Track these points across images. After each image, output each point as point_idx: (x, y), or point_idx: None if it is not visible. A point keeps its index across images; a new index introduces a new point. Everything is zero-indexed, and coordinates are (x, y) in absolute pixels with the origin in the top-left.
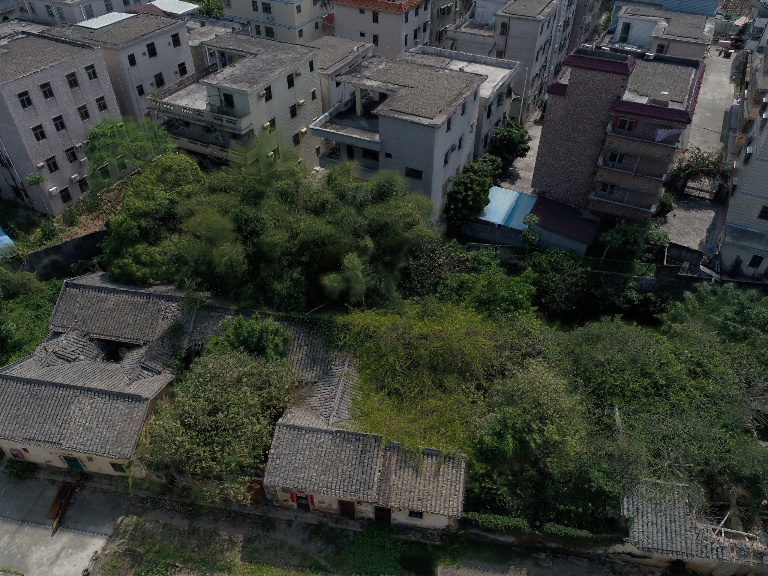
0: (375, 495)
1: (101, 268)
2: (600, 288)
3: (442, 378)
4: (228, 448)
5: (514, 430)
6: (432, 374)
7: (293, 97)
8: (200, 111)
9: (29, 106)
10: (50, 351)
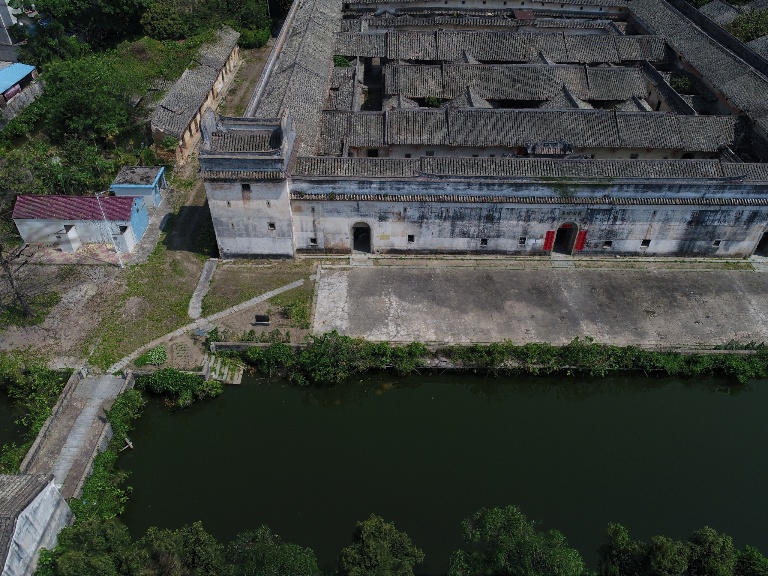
0: None
1: None
2: None
3: None
4: None
5: None
6: None
7: None
8: None
9: None
10: (739, 6)
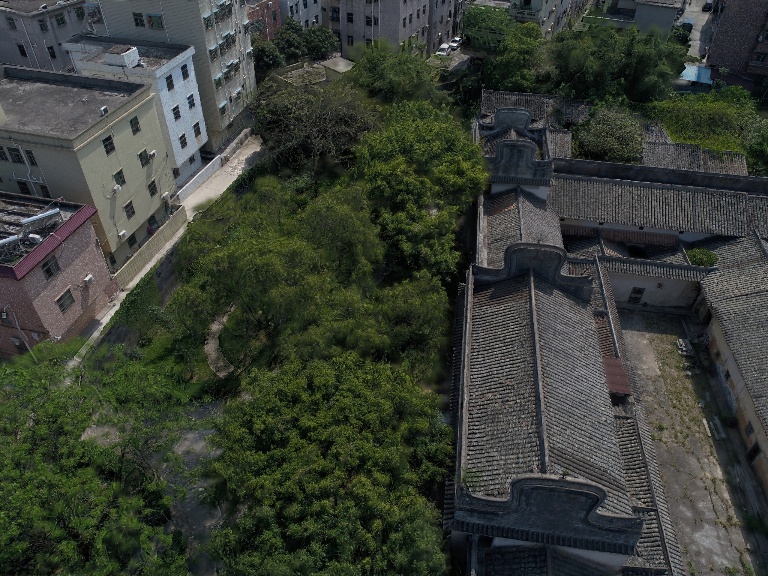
0: (703, 169)
1: (461, 101)
2: (762, 115)
3: (715, 129)
4: (629, 146)
5: (767, 142)
6: (708, 128)
7: (551, 5)
8: (508, 9)
9: (405, 4)
10: None
